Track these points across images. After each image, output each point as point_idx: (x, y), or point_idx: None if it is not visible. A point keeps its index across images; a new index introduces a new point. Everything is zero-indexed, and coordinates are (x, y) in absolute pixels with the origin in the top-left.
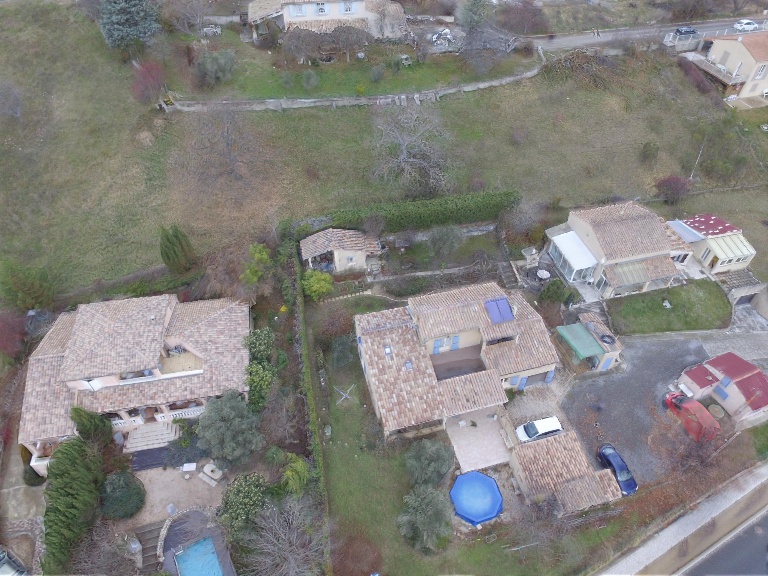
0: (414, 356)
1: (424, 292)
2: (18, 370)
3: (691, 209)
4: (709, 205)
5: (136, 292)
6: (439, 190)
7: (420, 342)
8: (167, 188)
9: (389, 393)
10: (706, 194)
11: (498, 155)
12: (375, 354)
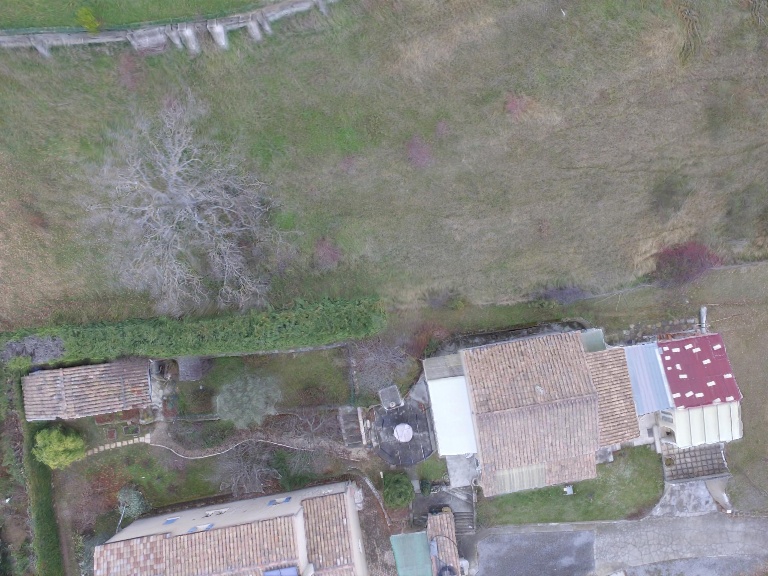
0: None
1: (226, 443)
2: None
3: (701, 294)
4: (738, 287)
5: None
6: (258, 262)
7: None
8: None
9: None
10: (743, 268)
11: (377, 182)
12: None
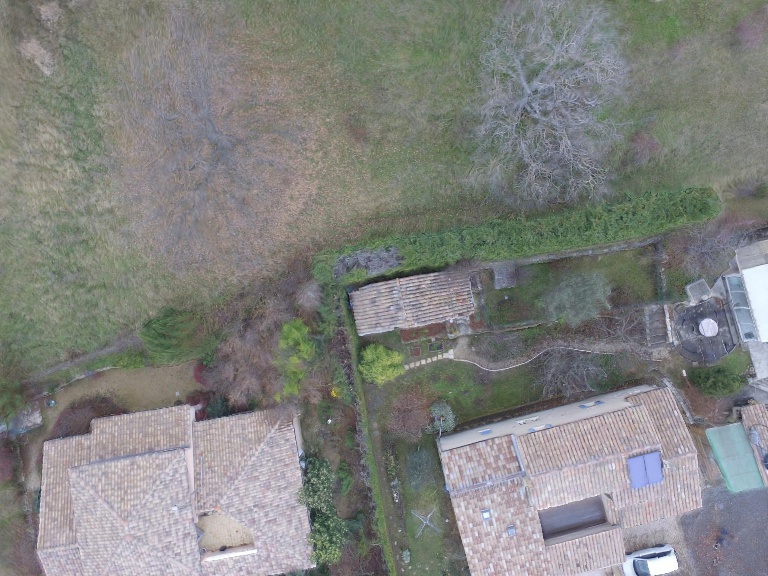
0: (519, 519)
1: (528, 353)
2: (23, 493)
3: None
4: None
5: (127, 368)
6: None
7: (529, 501)
8: (110, 175)
9: (485, 563)
10: None
11: (696, 71)
12: (470, 519)
